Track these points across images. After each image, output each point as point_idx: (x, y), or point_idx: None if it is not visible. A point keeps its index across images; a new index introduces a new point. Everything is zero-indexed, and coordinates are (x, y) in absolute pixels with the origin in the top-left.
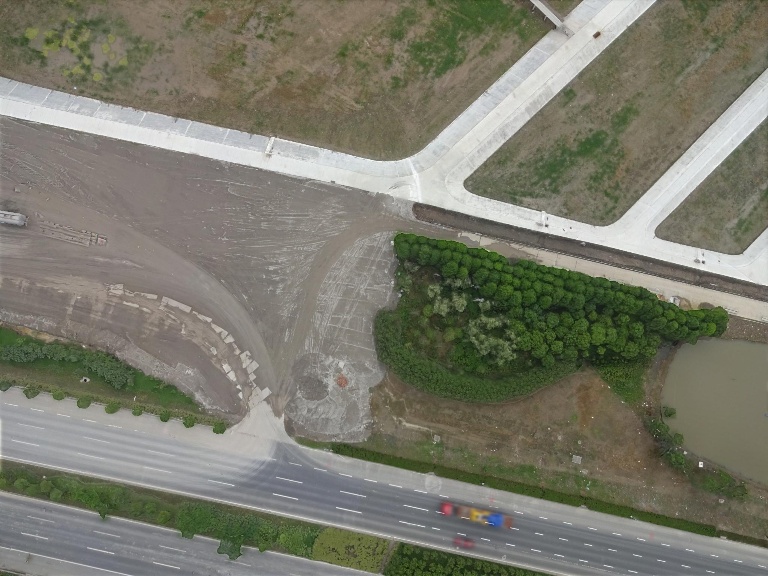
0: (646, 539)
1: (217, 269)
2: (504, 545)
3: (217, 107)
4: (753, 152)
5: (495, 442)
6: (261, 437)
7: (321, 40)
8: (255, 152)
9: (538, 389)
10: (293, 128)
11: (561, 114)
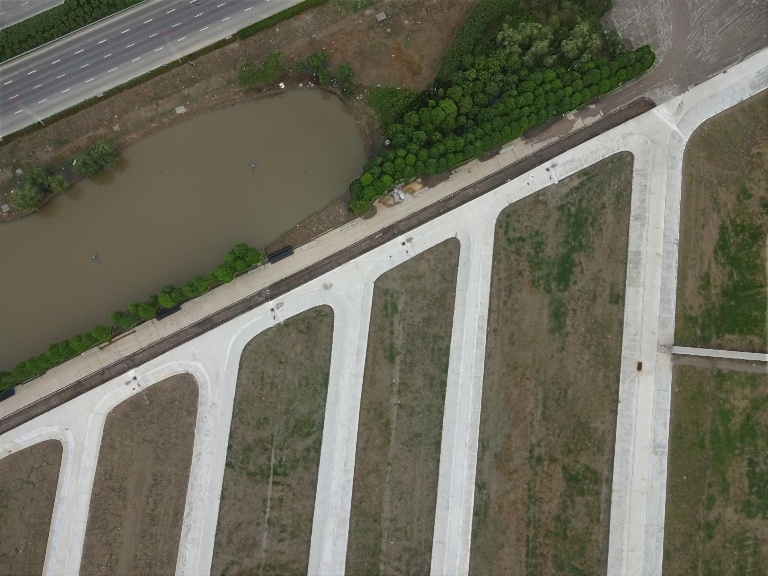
0: None
1: None
2: None
3: None
4: (430, 382)
5: None
6: None
7: None
8: None
9: None
10: None
11: (608, 276)
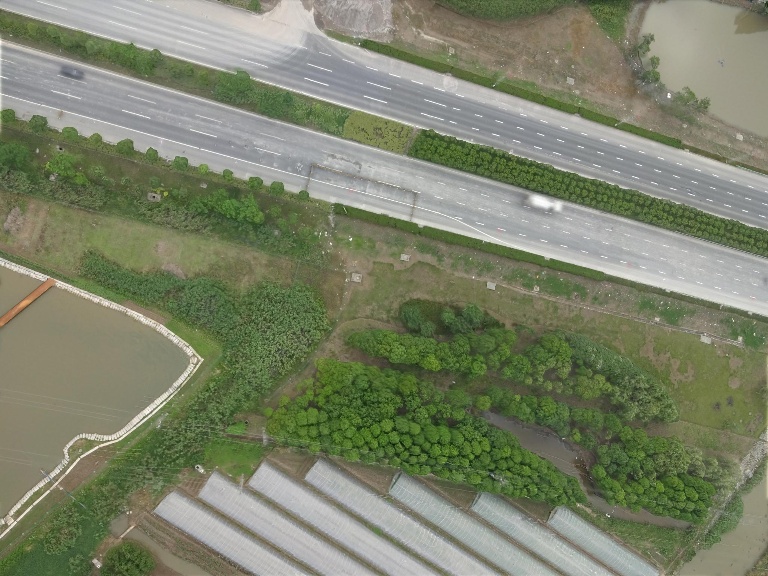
0: (627, 146)
1: None
2: (511, 141)
3: None
4: None
5: (502, 59)
6: (292, 26)
7: None
8: None
9: (538, 18)
10: None
11: None
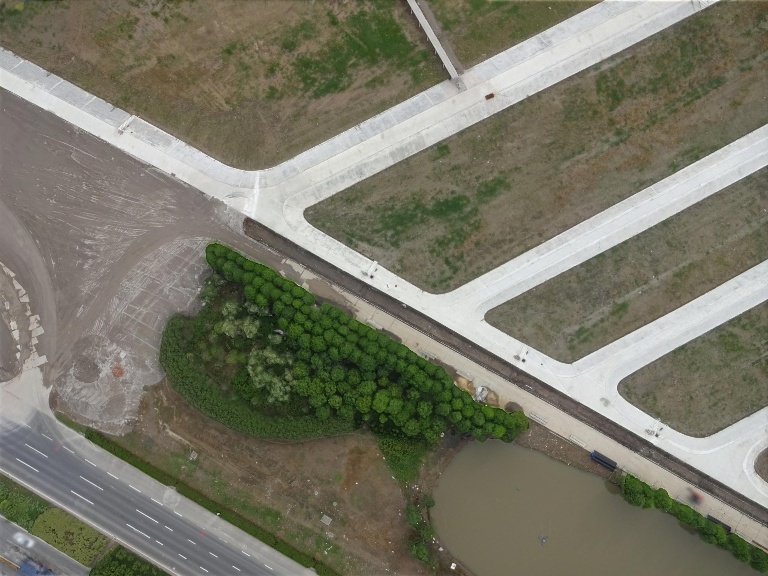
0: None
1: (36, 228)
2: None
3: (92, 72)
4: (620, 261)
5: (250, 477)
6: (24, 401)
7: (212, 32)
8: (109, 125)
9: (311, 438)
10: (157, 111)
11: (428, 168)
